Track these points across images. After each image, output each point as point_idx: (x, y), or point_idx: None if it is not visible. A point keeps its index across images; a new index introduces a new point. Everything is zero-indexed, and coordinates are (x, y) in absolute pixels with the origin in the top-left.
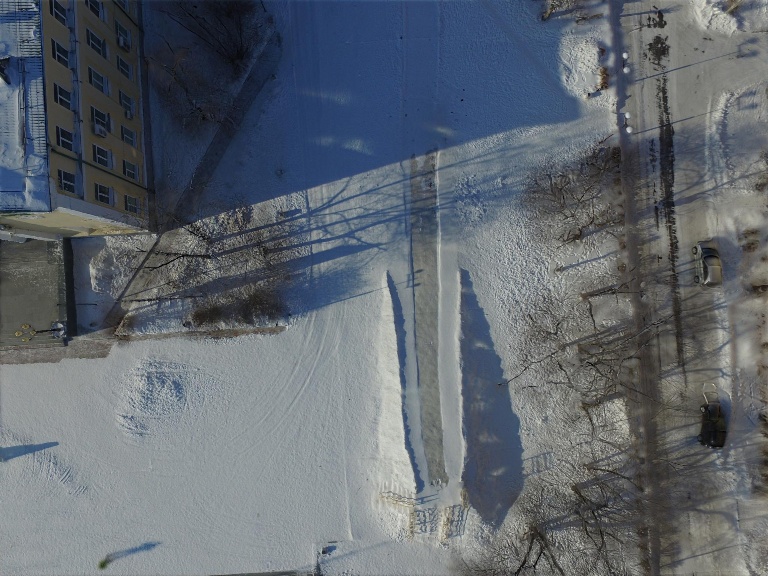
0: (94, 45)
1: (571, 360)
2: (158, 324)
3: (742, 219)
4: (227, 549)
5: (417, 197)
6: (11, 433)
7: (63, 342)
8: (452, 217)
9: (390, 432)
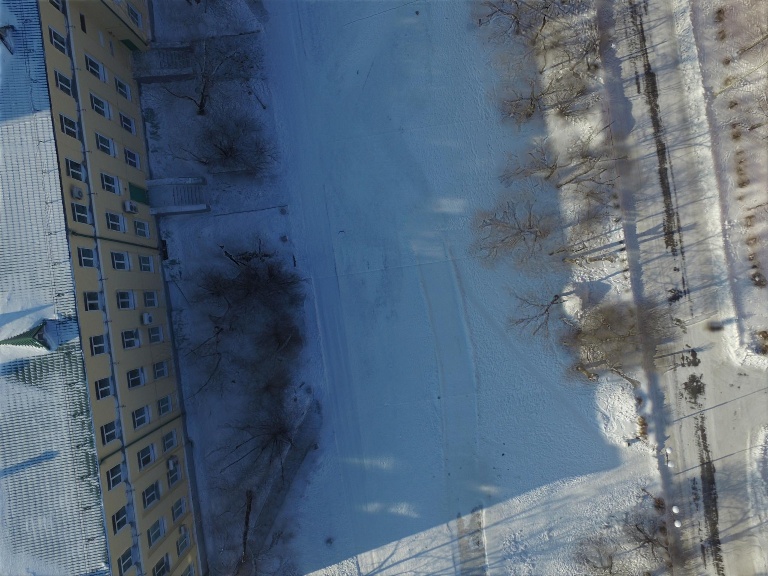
0: (149, 497)
1: None
2: None
3: None
4: None
5: (466, 557)
6: None
7: None
8: (502, 575)
9: None
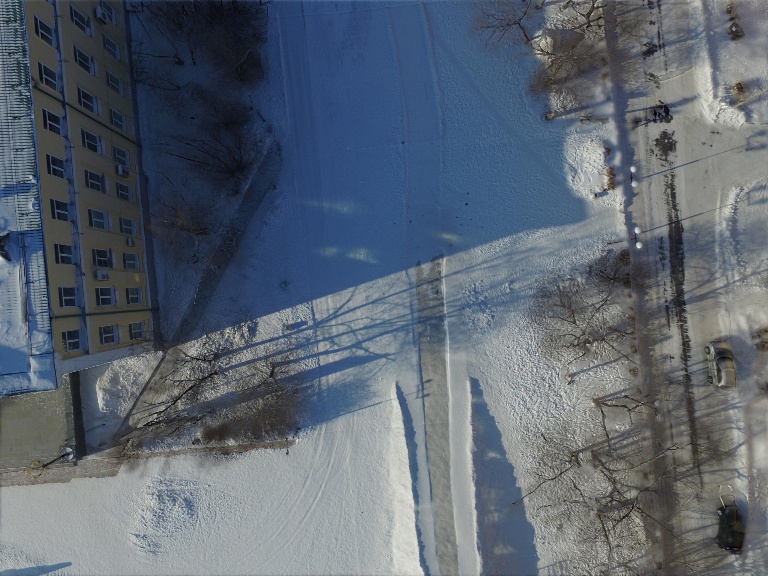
0: (93, 183)
1: (585, 466)
2: (167, 442)
3: (755, 317)
4: None
5: (424, 305)
6: (24, 554)
7: (72, 462)
8: (460, 325)
9: (404, 547)
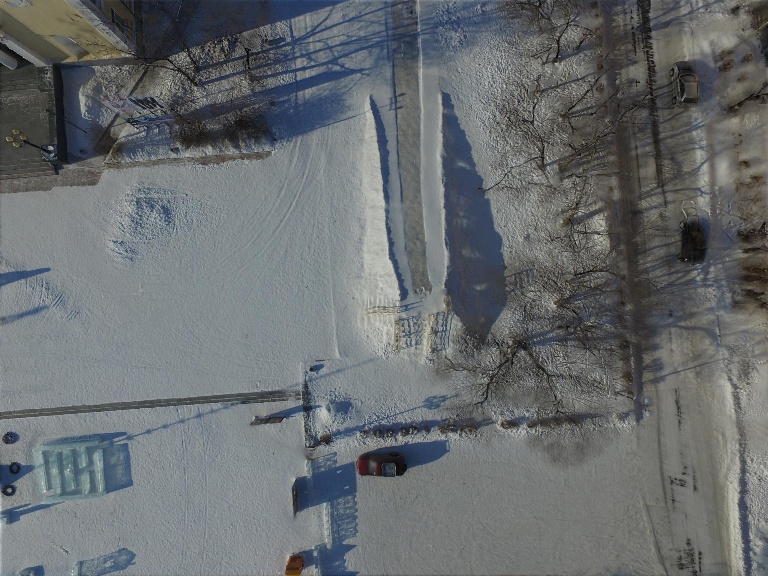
0: None
1: (552, 179)
2: (147, 151)
3: (718, 42)
4: (216, 370)
5: (399, 24)
6: (4, 260)
7: (54, 170)
8: (433, 42)
9: (375, 248)
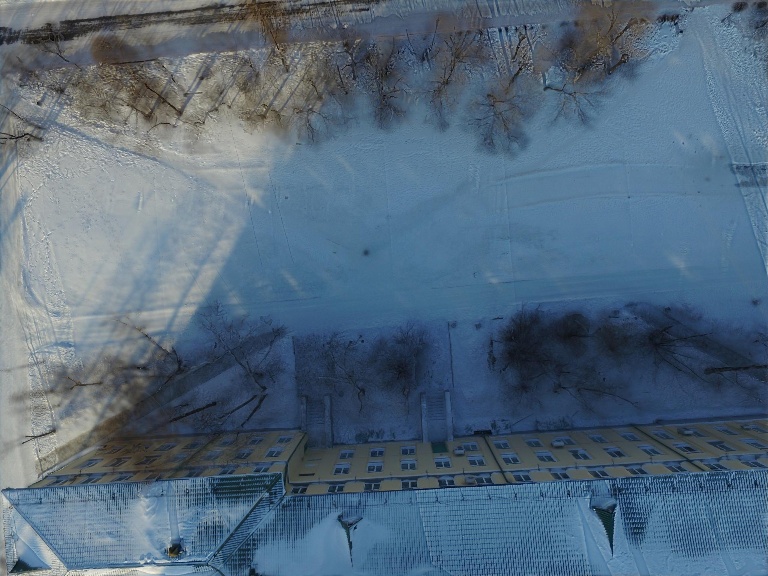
0: None
1: None
2: None
3: None
4: None
5: None
6: None
7: None
8: None
9: None
